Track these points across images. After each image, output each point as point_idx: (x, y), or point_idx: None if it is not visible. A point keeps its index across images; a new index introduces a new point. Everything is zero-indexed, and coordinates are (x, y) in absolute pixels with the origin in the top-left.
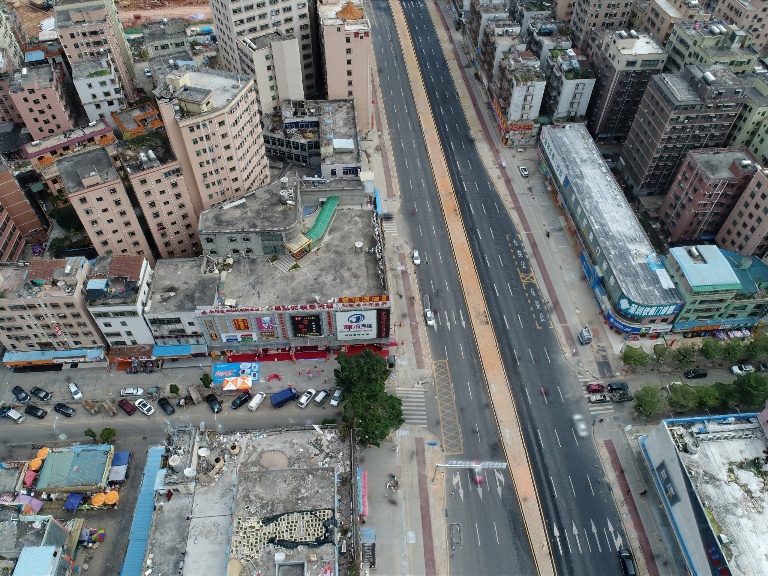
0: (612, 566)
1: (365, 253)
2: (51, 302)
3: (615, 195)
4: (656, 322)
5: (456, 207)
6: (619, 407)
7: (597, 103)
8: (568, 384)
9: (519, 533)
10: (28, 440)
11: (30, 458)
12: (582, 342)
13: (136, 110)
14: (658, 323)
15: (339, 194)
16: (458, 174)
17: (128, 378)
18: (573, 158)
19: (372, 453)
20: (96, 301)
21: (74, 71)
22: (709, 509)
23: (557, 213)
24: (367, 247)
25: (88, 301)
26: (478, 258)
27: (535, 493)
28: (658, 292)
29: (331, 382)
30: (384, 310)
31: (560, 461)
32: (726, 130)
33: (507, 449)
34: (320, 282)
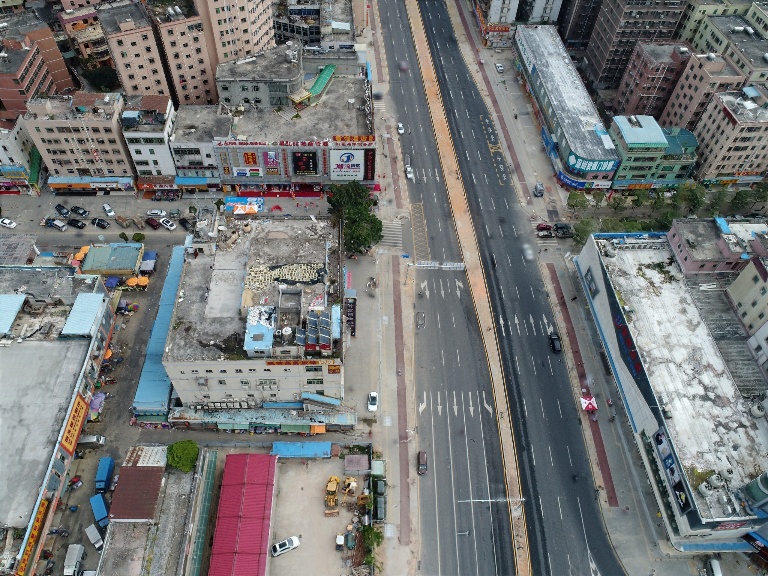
0: (543, 344)
1: (356, 109)
2: (93, 126)
3: (574, 80)
4: (598, 178)
5: (438, 92)
6: (562, 242)
7: (567, 10)
8: (522, 224)
9: (472, 321)
10: (71, 243)
11: (74, 255)
12: (536, 194)
13: None
14: (600, 179)
15: (336, 63)
16: (441, 67)
17: (153, 204)
18: (541, 51)
19: (356, 263)
20: (130, 129)
21: None
22: (619, 292)
23: (525, 101)
24: (358, 105)
25: (123, 127)
26: (454, 131)
27: (487, 295)
28: (601, 151)
29: (324, 214)
30: (370, 150)
31: (509, 276)
32: (673, 27)
33: (467, 265)
34: (317, 128)
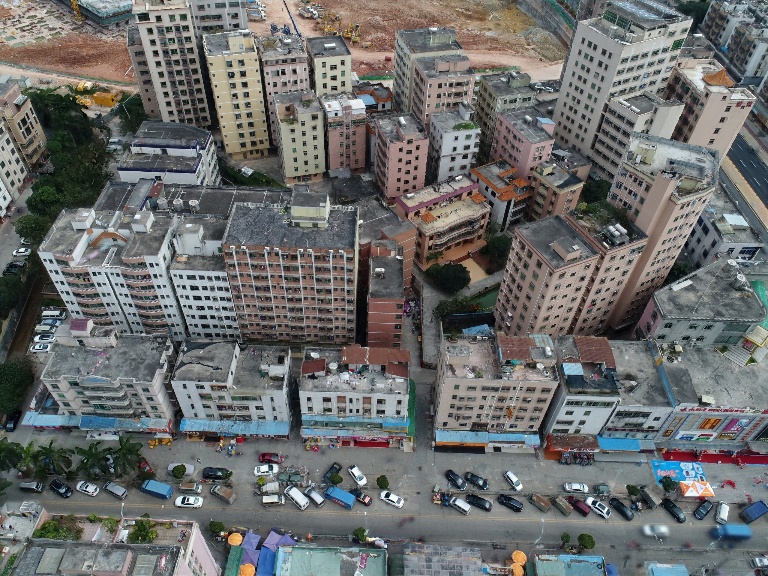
0: None
1: None
2: (529, 386)
3: None
4: None
5: None
6: None
7: None
8: None
9: None
10: (484, 537)
11: (496, 560)
12: None
13: (493, 166)
14: None
15: (765, 279)
16: None
17: (562, 469)
18: None
19: None
20: (570, 387)
21: (437, 122)
22: None
23: None
24: None
25: (566, 387)
26: None
27: None
28: None
29: None
30: None
31: None
32: None
33: None
34: None
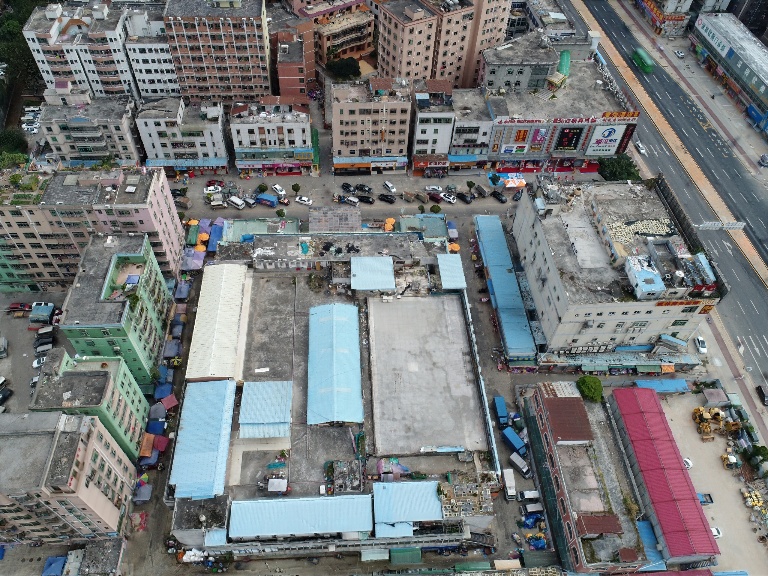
0: None
1: (602, 90)
2: (392, 108)
3: None
4: None
5: (634, 77)
6: None
7: None
8: (759, 191)
9: (752, 275)
10: None
11: None
12: (763, 164)
13: None
14: None
15: (571, 49)
16: (627, 54)
17: (425, 181)
18: (732, 36)
19: None
20: (421, 110)
21: None
22: None
23: (715, 83)
24: (602, 86)
25: (418, 108)
26: (663, 111)
27: (757, 253)
28: None
29: None
30: (632, 125)
31: None
32: None
33: None
34: (576, 107)
